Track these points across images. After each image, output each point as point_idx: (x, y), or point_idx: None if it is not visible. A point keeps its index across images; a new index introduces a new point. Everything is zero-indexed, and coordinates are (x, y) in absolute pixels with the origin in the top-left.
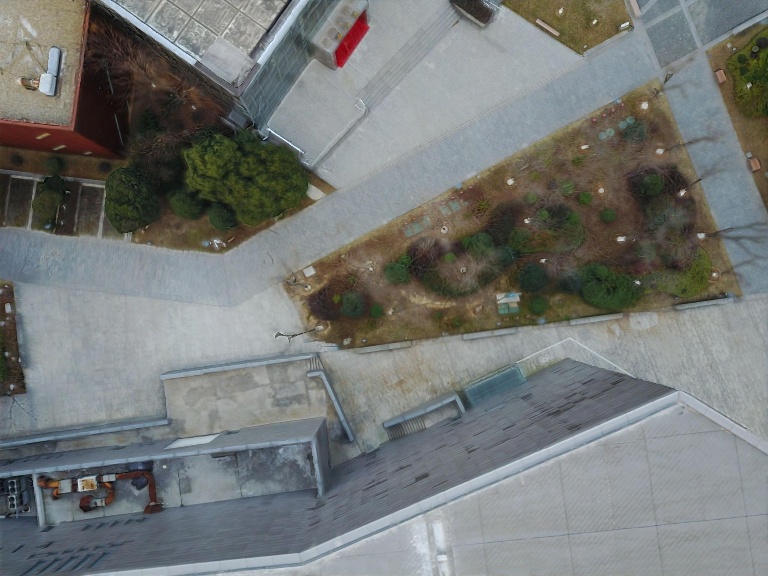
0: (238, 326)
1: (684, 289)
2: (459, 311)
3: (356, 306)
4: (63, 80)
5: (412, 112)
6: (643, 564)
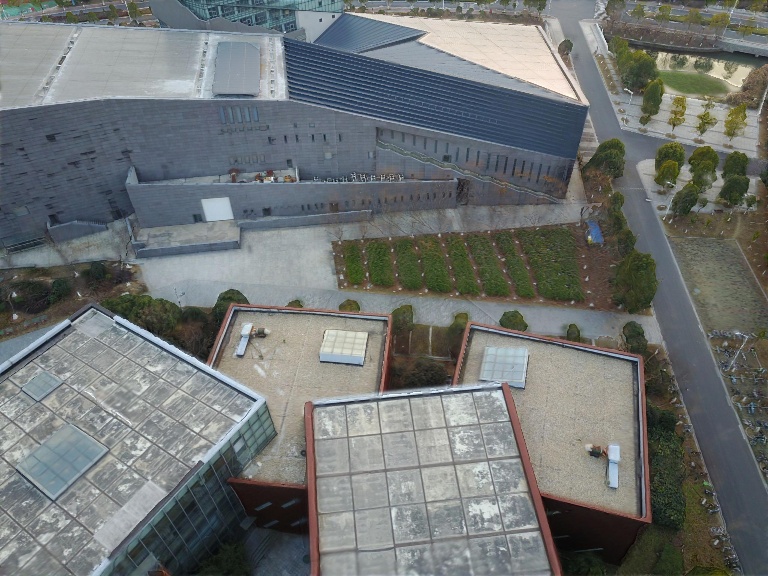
0: (186, 271)
1: None
2: (30, 276)
3: (92, 264)
4: (239, 339)
5: None
6: None
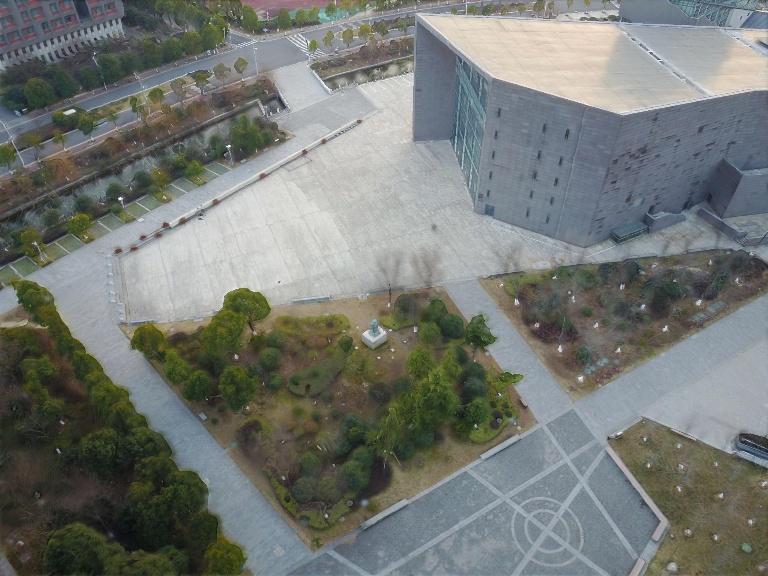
0: None
1: (522, 277)
2: (666, 265)
3: (741, 252)
4: None
5: (763, 373)
6: (612, 82)
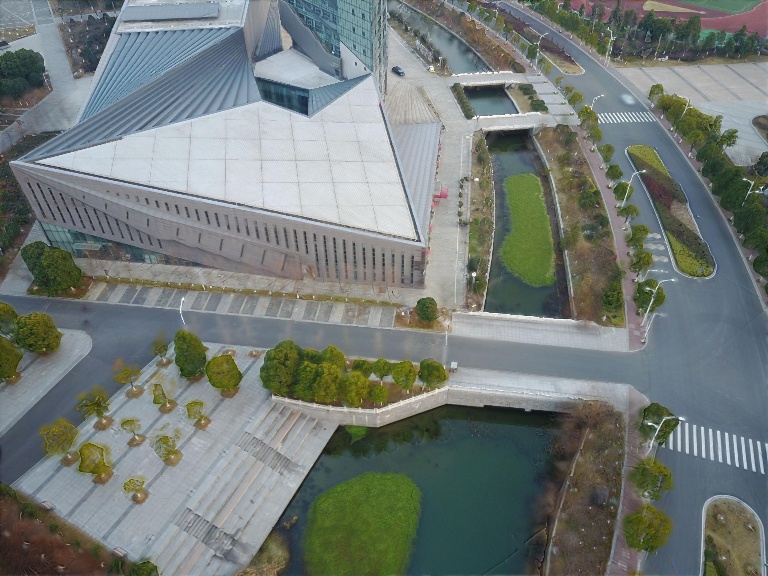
0: (86, 87)
1: None
2: None
3: None
4: None
5: None
6: None
